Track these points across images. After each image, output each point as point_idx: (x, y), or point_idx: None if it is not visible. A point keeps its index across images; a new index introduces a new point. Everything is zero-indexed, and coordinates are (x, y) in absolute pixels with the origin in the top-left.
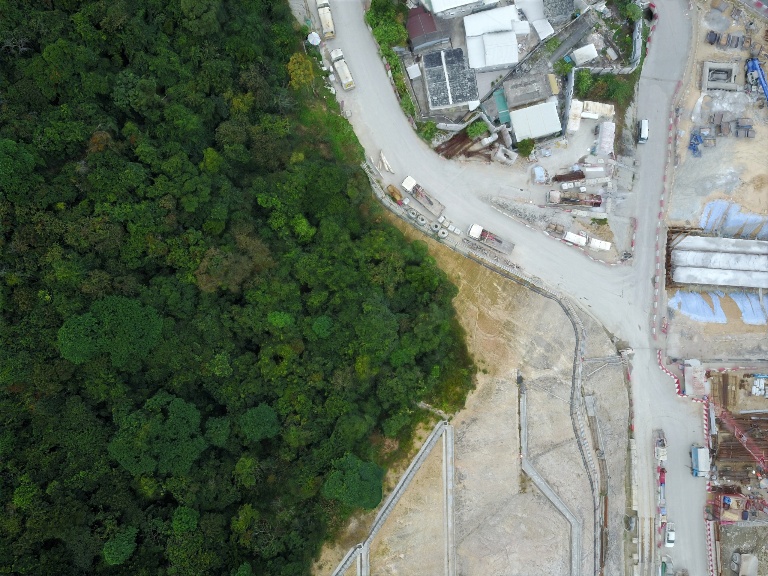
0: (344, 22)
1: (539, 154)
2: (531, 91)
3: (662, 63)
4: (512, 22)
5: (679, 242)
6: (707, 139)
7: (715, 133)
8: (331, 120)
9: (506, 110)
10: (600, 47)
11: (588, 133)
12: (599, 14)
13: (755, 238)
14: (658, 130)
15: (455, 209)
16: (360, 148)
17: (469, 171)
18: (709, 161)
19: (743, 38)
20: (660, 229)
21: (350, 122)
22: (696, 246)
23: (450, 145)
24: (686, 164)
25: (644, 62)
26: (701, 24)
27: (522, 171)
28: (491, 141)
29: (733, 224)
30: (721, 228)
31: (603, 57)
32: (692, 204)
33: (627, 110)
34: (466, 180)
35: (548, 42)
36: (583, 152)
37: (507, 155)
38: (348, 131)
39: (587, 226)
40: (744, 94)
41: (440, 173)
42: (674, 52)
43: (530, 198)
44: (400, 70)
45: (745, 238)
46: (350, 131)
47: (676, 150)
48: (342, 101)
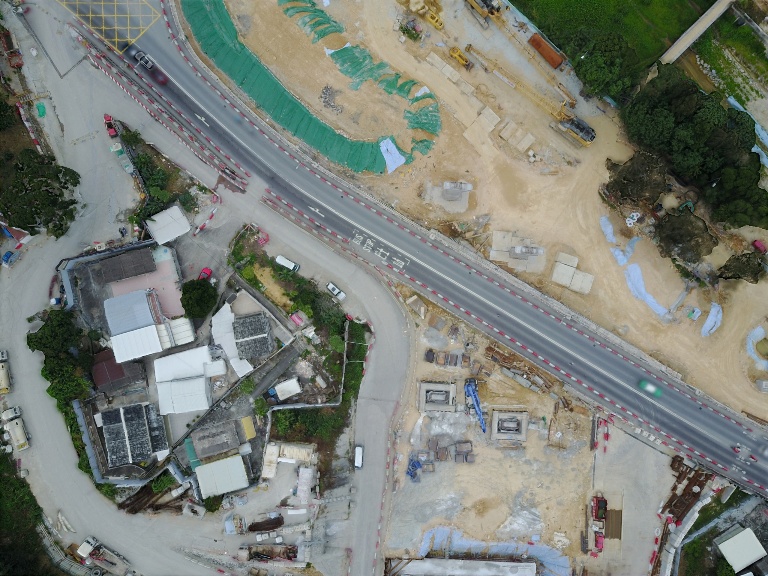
0: (25, 372)
1: (235, 501)
2: (220, 442)
3: (381, 382)
4: (204, 365)
5: (400, 570)
6: (425, 464)
7: (434, 457)
8: (0, 487)
9: (197, 459)
10: (308, 376)
11: (291, 472)
12: (308, 340)
13: (486, 555)
14: (377, 453)
15: (146, 562)
16: (34, 512)
17: (160, 522)
18: (429, 486)
19: (461, 358)
20: (378, 559)
21: (28, 480)
22: (422, 569)
23: (136, 500)
24: (405, 489)
25: (362, 382)
26: (420, 341)
27: (217, 519)
28: (181, 492)
29: (459, 547)
30: (449, 548)
31: (312, 385)
32: (412, 531)
33: (339, 439)
34: (156, 532)
35: (251, 375)
36: (286, 492)
37: (195, 510)
38: (20, 496)
39: (292, 568)
40: (465, 414)
41: (127, 527)
42: (393, 371)
43: (225, 549)
44: (78, 427)
45: (474, 558)
46: (23, 495)
47: (393, 476)
48: (19, 459)
